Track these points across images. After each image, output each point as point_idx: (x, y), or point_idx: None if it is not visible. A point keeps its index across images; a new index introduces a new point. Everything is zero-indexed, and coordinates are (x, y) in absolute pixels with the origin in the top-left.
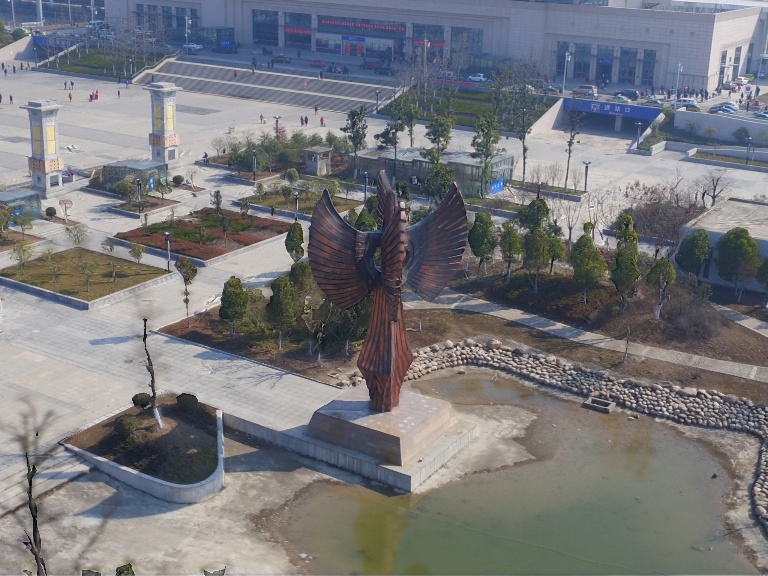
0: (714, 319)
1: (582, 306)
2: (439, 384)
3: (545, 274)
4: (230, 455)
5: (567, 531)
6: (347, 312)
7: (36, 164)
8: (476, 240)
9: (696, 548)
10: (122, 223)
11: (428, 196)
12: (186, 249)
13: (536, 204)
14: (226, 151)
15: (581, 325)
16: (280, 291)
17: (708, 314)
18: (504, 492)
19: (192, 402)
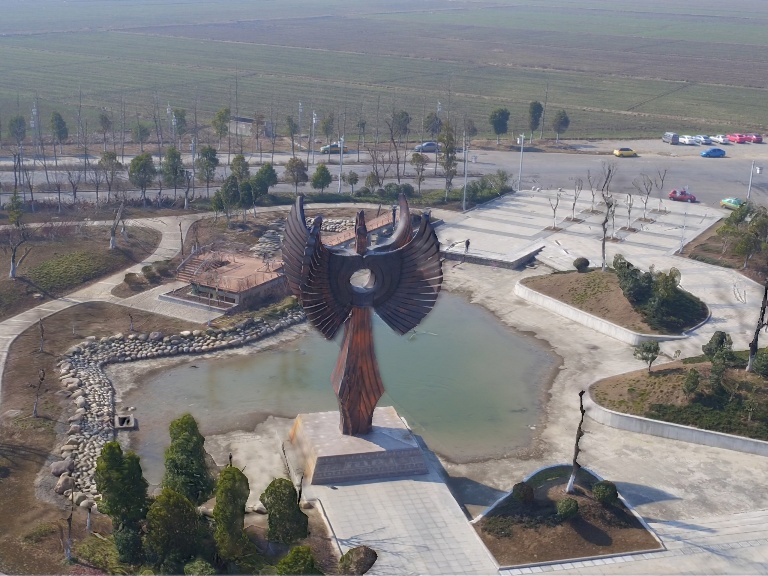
0: None
1: None
2: None
3: None
4: None
5: None
6: None
7: None
8: None
9: (304, 353)
10: None
11: None
12: None
13: None
14: None
15: None
16: None
17: None
18: None
19: None
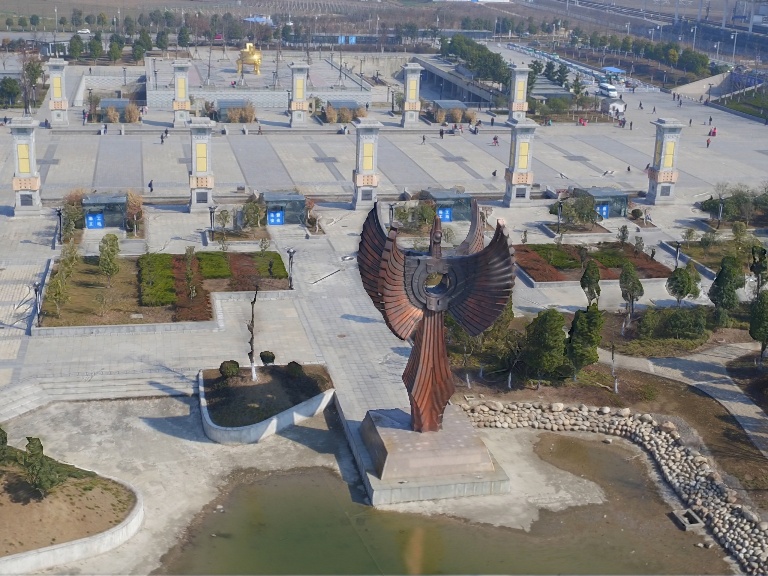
0: None
1: None
2: (567, 442)
3: None
4: (302, 425)
5: None
6: (510, 344)
7: (508, 175)
8: (752, 320)
9: None
10: (533, 238)
11: None
12: (534, 269)
13: None
14: None
15: None
16: None
17: None
18: (447, 541)
19: (293, 370)
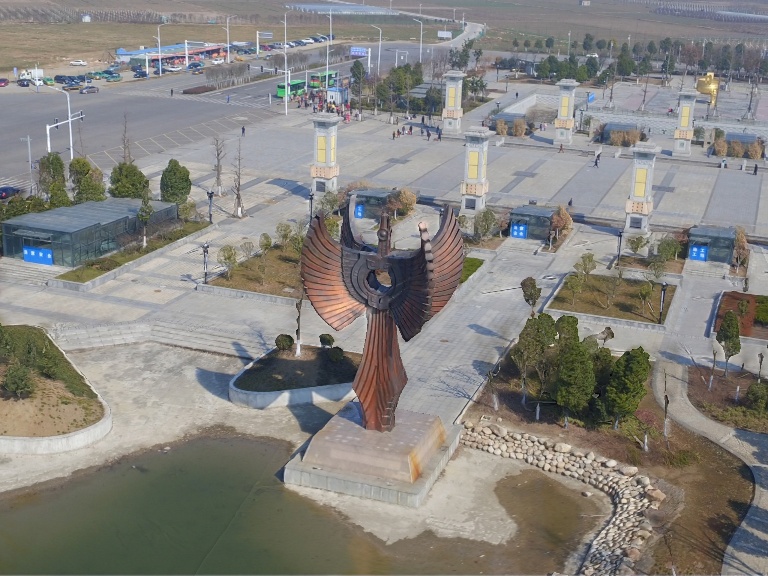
0: None
1: None
2: (543, 484)
3: None
4: (319, 405)
5: (241, 567)
6: (538, 372)
7: None
8: None
9: None
10: None
11: None
12: None
13: None
14: None
15: None
16: None
17: None
18: (305, 529)
19: (331, 354)
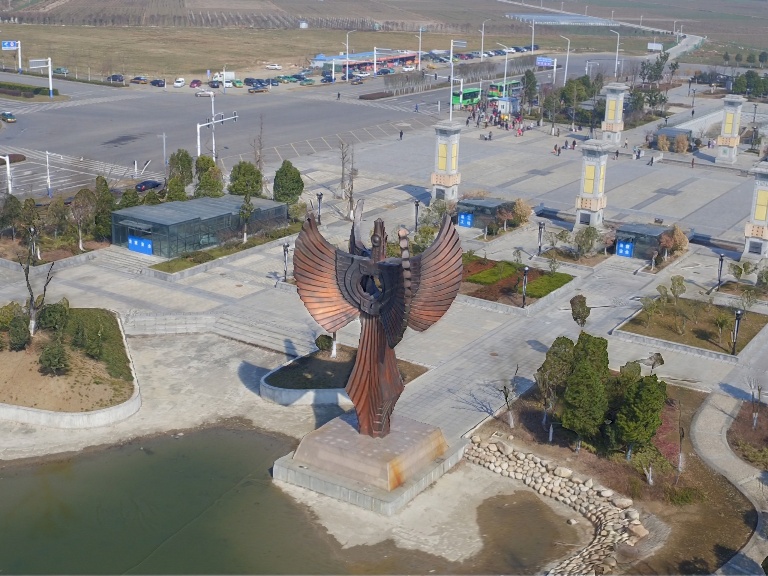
0: None
1: None
2: (532, 507)
3: None
4: (344, 407)
5: (195, 553)
6: None
7: None
8: None
9: None
10: None
11: None
12: None
13: None
14: None
15: None
16: None
17: None
18: (271, 524)
19: None
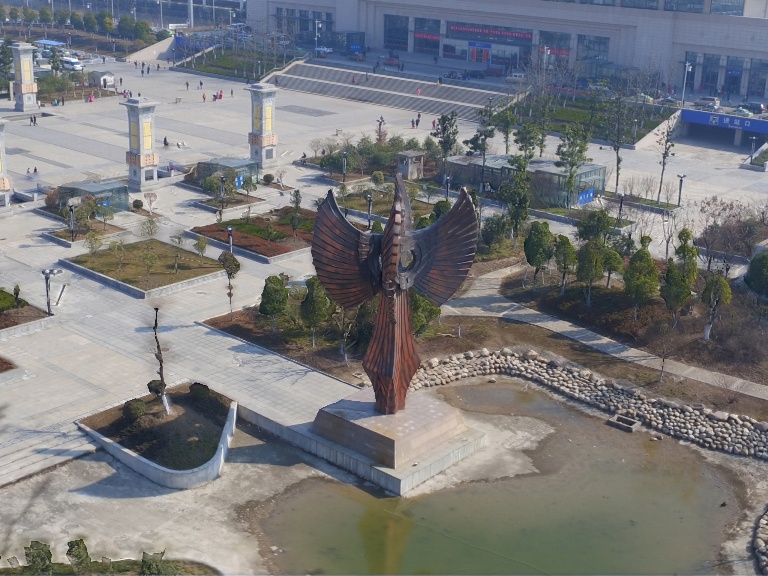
0: (767, 343)
1: (632, 321)
2: (465, 391)
3: (602, 287)
4: (236, 446)
5: (548, 547)
6: None
7: (133, 158)
8: (531, 249)
9: None
10: (204, 218)
11: (501, 203)
12: (254, 245)
13: (596, 215)
14: (326, 152)
15: (628, 341)
16: (314, 289)
17: (761, 337)
18: (495, 503)
19: (203, 392)
